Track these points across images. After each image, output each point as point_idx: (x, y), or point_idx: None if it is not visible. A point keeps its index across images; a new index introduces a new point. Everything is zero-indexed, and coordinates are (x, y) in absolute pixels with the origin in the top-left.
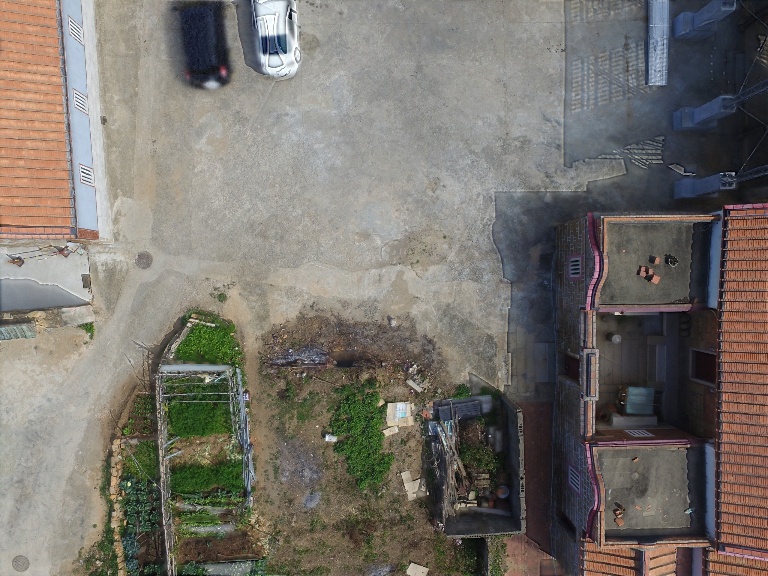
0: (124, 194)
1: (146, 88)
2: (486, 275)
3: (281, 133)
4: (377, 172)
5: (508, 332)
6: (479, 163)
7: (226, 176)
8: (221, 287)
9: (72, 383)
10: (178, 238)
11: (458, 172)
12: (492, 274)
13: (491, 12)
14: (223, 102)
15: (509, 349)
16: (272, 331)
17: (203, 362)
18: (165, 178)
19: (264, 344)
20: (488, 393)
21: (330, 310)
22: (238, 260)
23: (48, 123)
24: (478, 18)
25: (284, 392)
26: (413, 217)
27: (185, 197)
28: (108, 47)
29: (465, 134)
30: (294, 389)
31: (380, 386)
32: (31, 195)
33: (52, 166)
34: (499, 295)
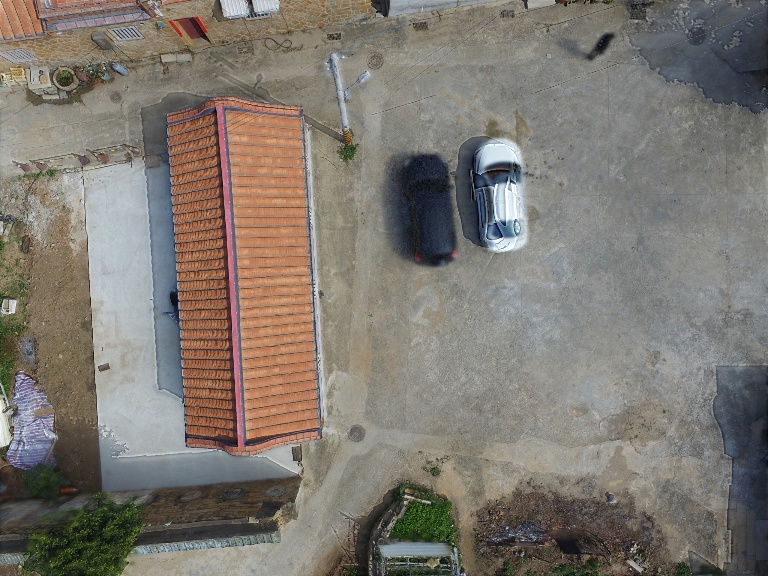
0: (339, 368)
1: (363, 261)
2: (707, 451)
3: (499, 306)
4: (596, 346)
5: (728, 509)
6: (700, 336)
7: (442, 349)
8: (434, 461)
9: (277, 554)
10: (392, 412)
11: (679, 346)
12: (713, 450)
13: (714, 183)
14: (441, 275)
15: (729, 526)
16: (488, 507)
17: (418, 540)
18: (381, 352)
19: (479, 521)
20: (708, 572)
21: (548, 487)
22: (453, 434)
23: (298, 325)
24: (701, 189)
25: (502, 572)
26: (632, 391)
27: (401, 371)
28: (325, 220)
29: (686, 307)
30: (512, 569)
31: (600, 566)
32: (284, 402)
33: (302, 369)
34: (720, 471)
